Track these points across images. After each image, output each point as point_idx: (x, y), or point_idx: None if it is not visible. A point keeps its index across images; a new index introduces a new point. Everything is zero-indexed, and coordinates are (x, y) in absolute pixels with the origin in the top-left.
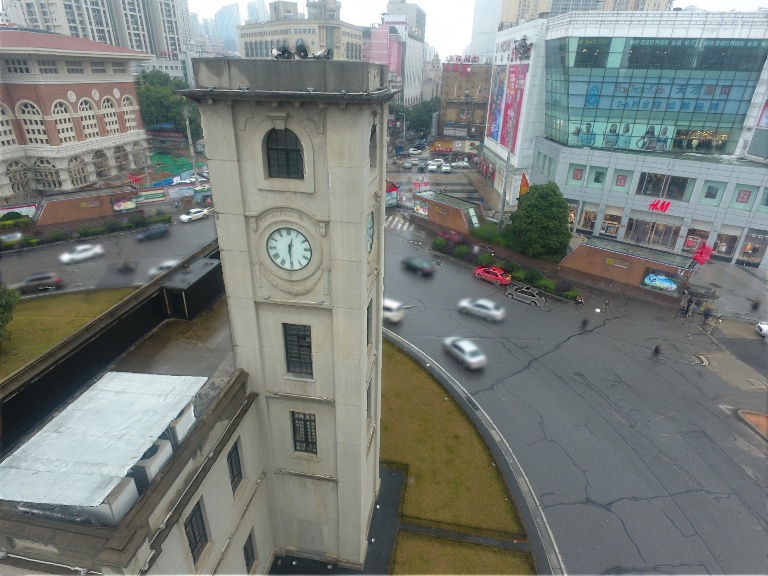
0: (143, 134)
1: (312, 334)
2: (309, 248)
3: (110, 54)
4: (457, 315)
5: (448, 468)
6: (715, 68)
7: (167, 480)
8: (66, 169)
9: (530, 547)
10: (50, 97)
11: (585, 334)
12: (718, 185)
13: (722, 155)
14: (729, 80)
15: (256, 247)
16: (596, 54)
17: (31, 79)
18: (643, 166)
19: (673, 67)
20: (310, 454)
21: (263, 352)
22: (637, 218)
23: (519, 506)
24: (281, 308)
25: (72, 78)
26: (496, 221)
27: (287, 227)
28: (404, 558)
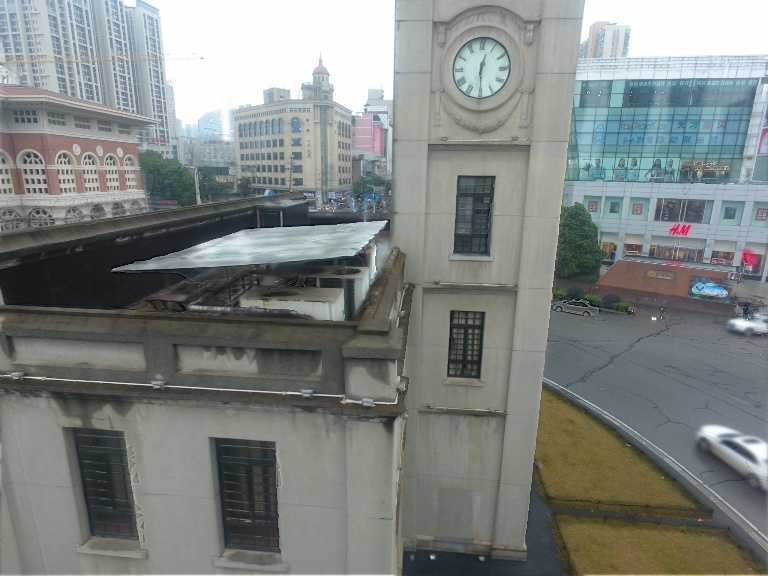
0: (142, 194)
1: (496, 188)
2: (506, 65)
3: (119, 113)
4: None
5: (578, 450)
6: (710, 105)
7: (386, 300)
8: (63, 219)
9: (722, 525)
10: (55, 147)
11: (654, 336)
12: (735, 205)
13: (728, 183)
14: (724, 115)
15: (440, 67)
16: (599, 95)
17: (38, 128)
18: (659, 192)
19: (671, 105)
20: (468, 379)
21: (427, 222)
22: (658, 244)
23: (682, 484)
24: (460, 153)
25: (79, 132)
26: None
27: (483, 36)
28: (574, 544)
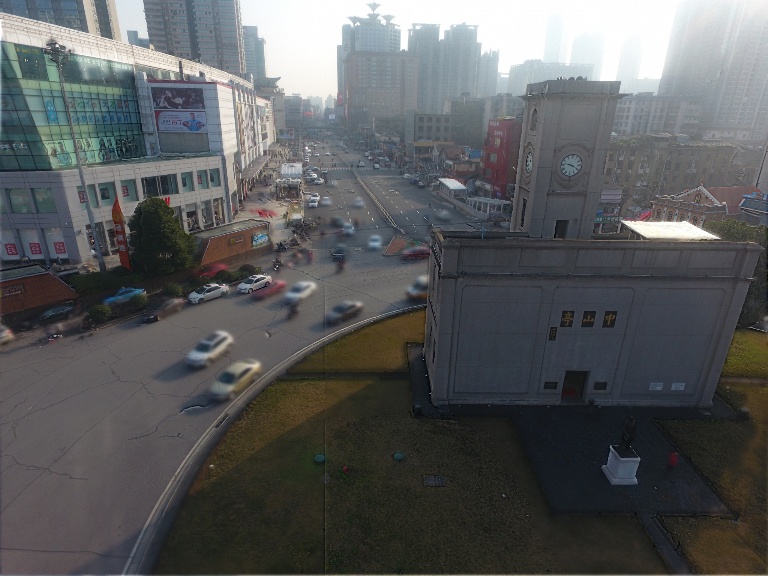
0: None
1: None
2: None
3: None
4: (286, 312)
5: None
6: (115, 85)
7: None
8: None
9: None
10: None
11: (312, 275)
12: (184, 175)
13: (146, 156)
14: (124, 96)
15: None
16: (36, 65)
17: None
18: (140, 173)
19: (93, 83)
20: None
21: None
22: None
23: None
24: None
25: None
26: (76, 271)
27: None
28: None
